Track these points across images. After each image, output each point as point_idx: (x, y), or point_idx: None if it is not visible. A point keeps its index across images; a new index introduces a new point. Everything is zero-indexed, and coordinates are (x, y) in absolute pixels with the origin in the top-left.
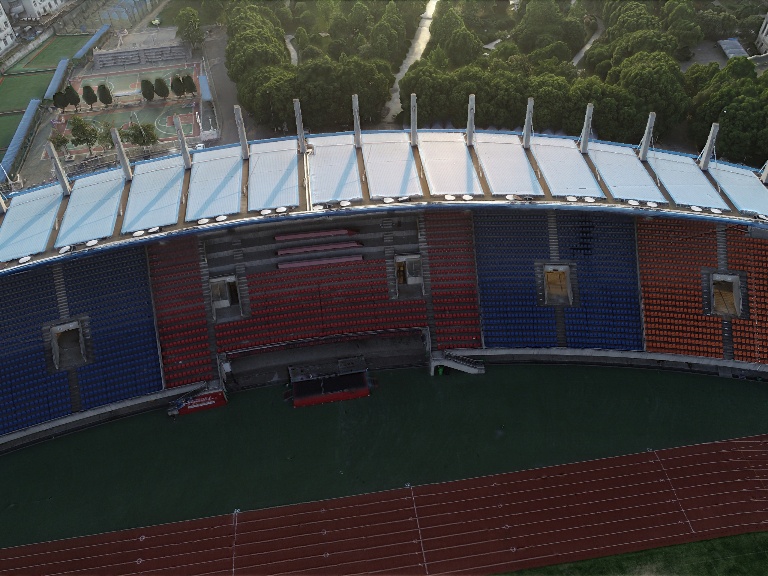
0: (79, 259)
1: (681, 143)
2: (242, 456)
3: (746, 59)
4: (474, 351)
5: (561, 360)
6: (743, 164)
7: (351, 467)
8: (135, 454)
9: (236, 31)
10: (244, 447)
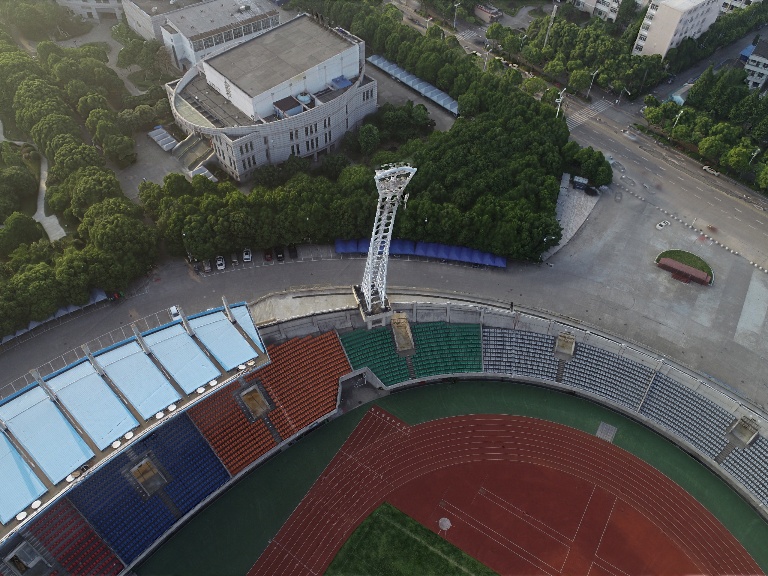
0: None
1: (170, 258)
2: None
3: (175, 176)
4: (121, 575)
5: (185, 521)
6: (220, 257)
7: None
8: None
9: None
10: None
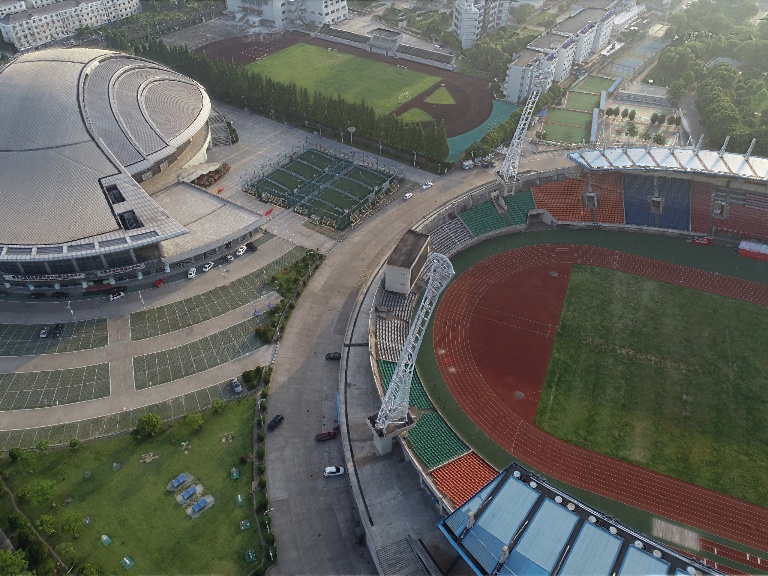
0: (665, 178)
1: None
2: (718, 261)
3: None
4: None
5: None
6: None
7: (763, 278)
8: (675, 248)
9: (710, 100)
10: (718, 259)
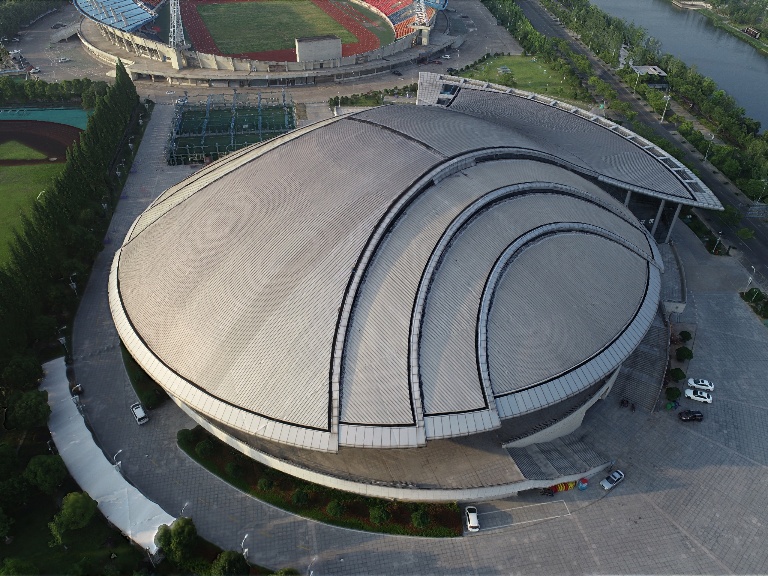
0: None
1: None
2: None
3: None
4: None
5: None
6: None
7: None
8: None
9: None
10: None
